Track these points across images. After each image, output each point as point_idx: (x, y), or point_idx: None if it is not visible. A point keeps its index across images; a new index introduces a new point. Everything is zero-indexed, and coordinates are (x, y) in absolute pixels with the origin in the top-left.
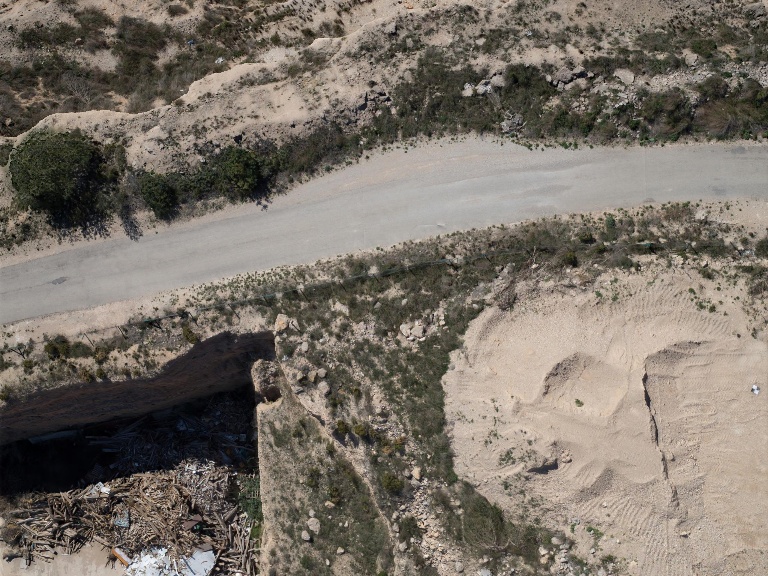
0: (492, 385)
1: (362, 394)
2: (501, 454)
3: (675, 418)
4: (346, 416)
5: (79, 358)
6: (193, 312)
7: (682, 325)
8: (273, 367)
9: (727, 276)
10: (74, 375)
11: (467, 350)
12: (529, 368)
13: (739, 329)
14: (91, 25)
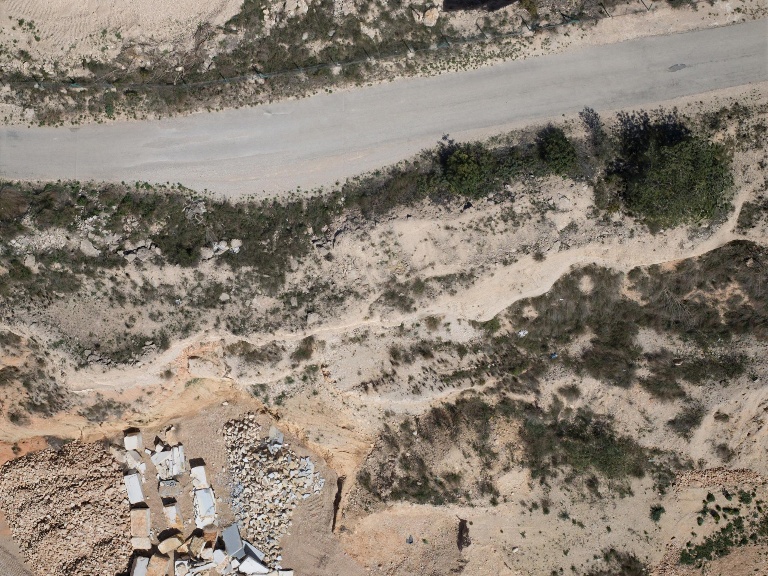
0: None
1: None
2: None
3: None
4: None
5: None
6: (526, 31)
7: (48, 8)
8: None
9: (8, 53)
10: None
11: None
12: None
13: None
14: (663, 378)
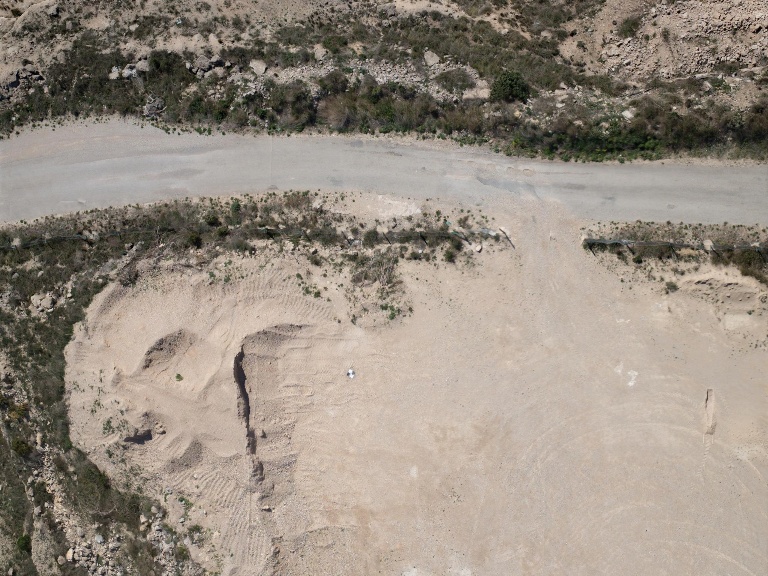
0: (103, 357)
1: None
2: (104, 423)
3: (272, 397)
4: None
5: None
6: None
7: (288, 308)
8: None
9: (334, 264)
10: None
11: (87, 322)
12: (137, 342)
13: (340, 315)
14: None
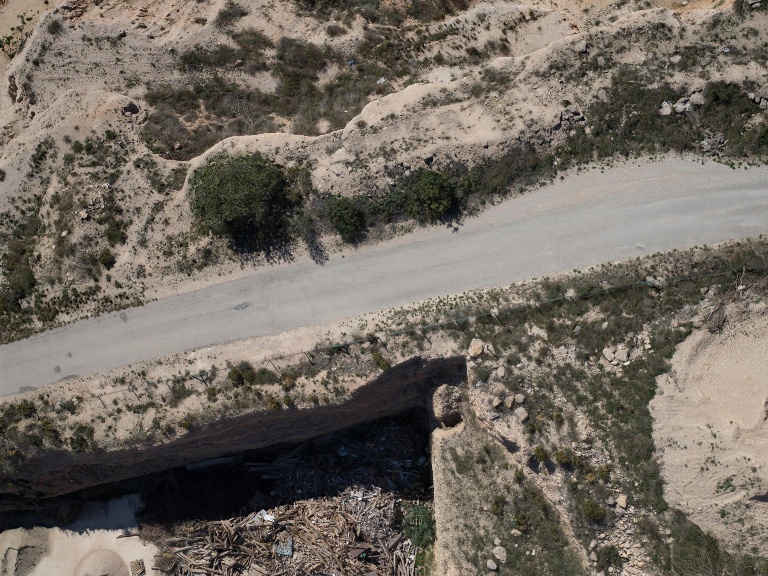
0: (706, 410)
1: (564, 420)
2: (719, 481)
3: None
4: (545, 442)
5: (264, 385)
6: (382, 337)
7: None
8: (457, 392)
9: None
10: (260, 402)
11: (676, 374)
12: (745, 393)
13: None
14: (252, 47)
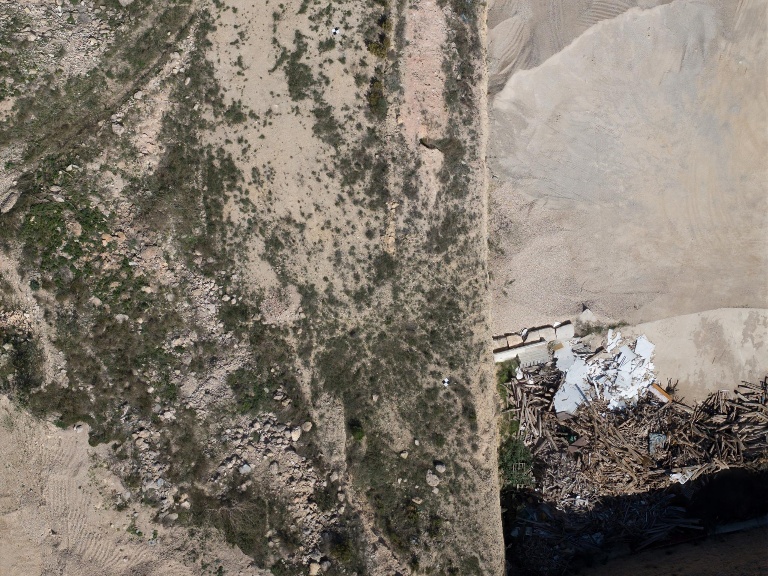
0: None
1: None
2: None
3: None
4: None
5: None
6: None
7: None
8: None
9: None
10: None
11: None
12: None
13: None
14: None
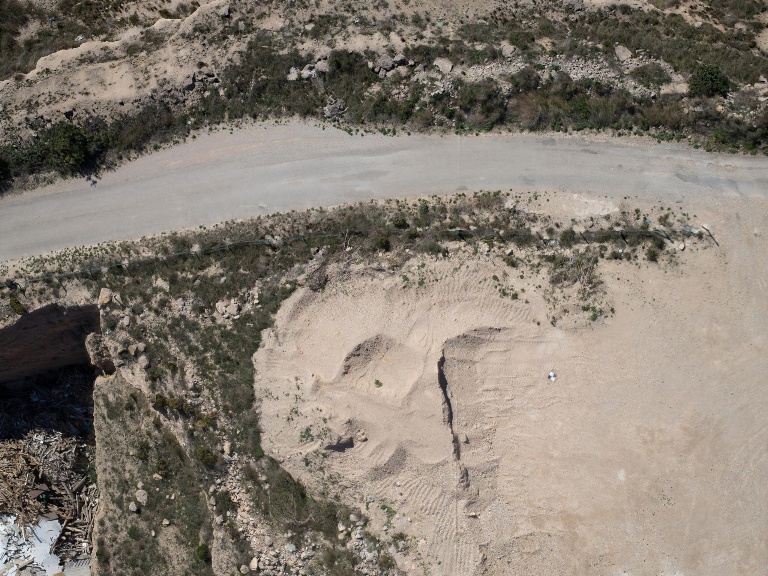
0: (297, 364)
1: (178, 369)
2: (301, 431)
3: (472, 402)
4: (164, 390)
5: None
6: (22, 283)
7: (485, 311)
8: None
9: (530, 265)
10: None
11: (277, 329)
12: (333, 348)
13: (539, 317)
14: None
